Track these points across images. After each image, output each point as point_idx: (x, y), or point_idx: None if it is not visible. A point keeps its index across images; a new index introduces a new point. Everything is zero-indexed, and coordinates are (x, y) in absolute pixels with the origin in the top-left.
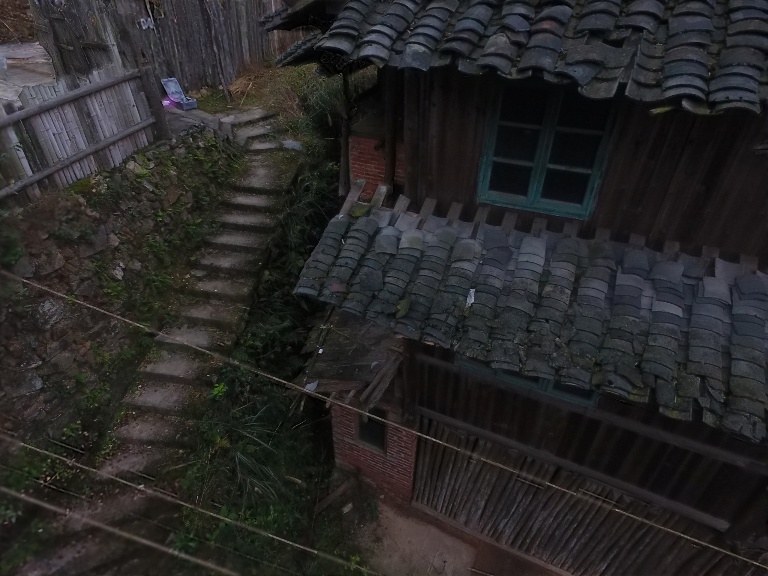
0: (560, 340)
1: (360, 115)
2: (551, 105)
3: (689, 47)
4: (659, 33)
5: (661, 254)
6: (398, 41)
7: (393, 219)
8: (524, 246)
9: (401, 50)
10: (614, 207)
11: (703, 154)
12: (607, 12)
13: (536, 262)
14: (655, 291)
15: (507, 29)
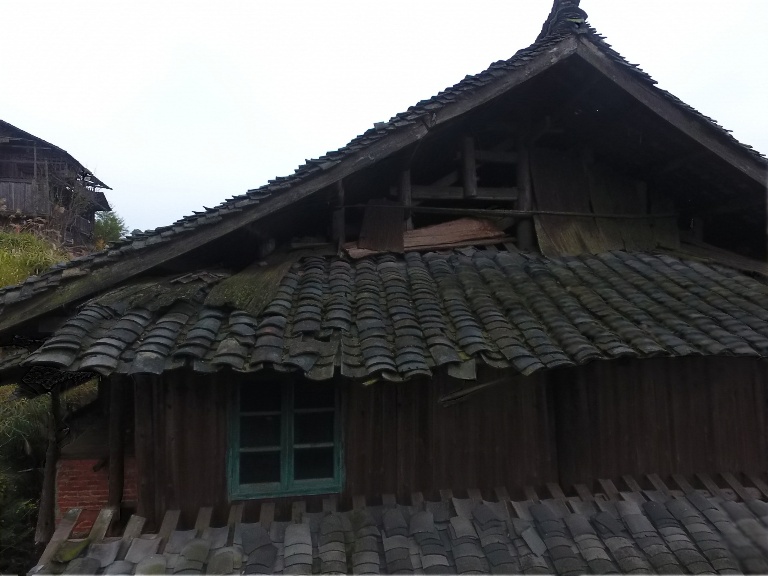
0: None
1: (73, 435)
2: (285, 392)
3: (374, 338)
4: (352, 331)
5: (412, 507)
6: (127, 351)
7: (122, 550)
8: (288, 537)
9: (131, 358)
10: (361, 473)
11: (411, 413)
12: (312, 319)
13: (304, 552)
14: (419, 546)
15: (235, 334)
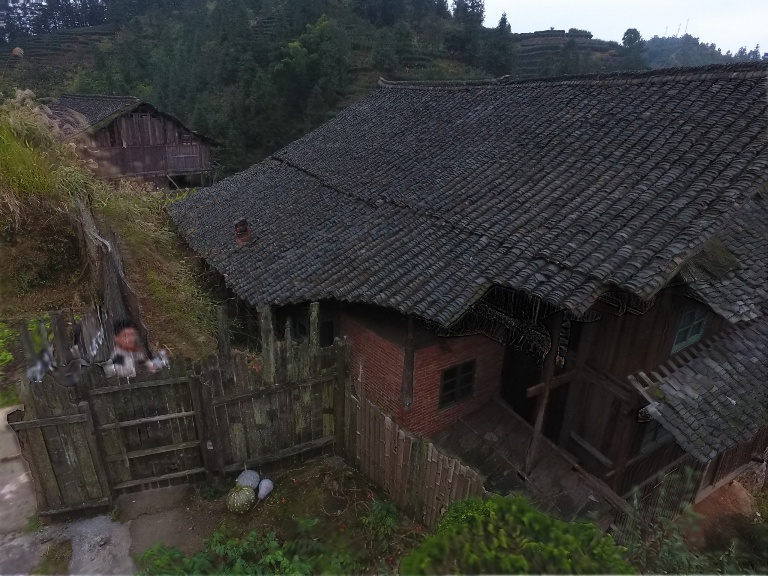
0: (763, 394)
1: None
2: None
3: None
4: None
5: (727, 339)
6: None
7: None
8: (710, 364)
9: None
10: None
11: None
12: None
13: None
14: (744, 355)
15: (760, 286)
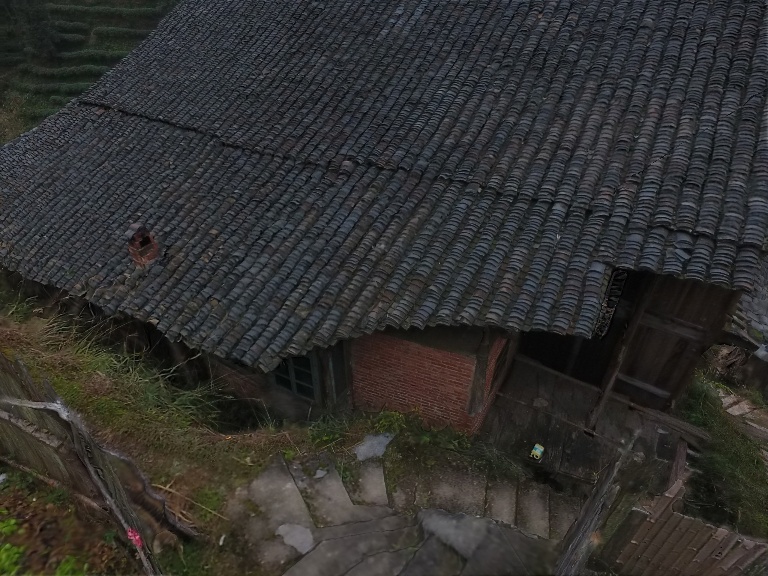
0: None
1: (328, 355)
2: None
3: None
4: None
5: None
6: None
7: None
8: None
9: None
10: None
11: None
12: None
13: None
14: None
15: None
